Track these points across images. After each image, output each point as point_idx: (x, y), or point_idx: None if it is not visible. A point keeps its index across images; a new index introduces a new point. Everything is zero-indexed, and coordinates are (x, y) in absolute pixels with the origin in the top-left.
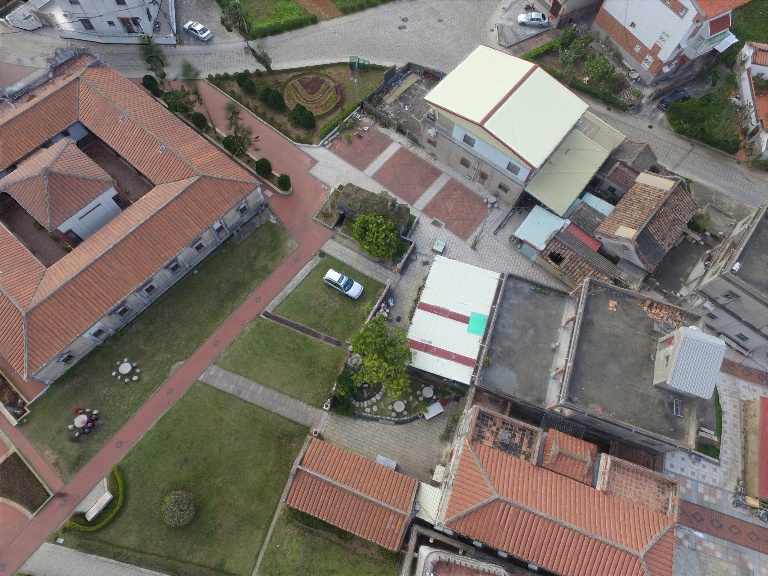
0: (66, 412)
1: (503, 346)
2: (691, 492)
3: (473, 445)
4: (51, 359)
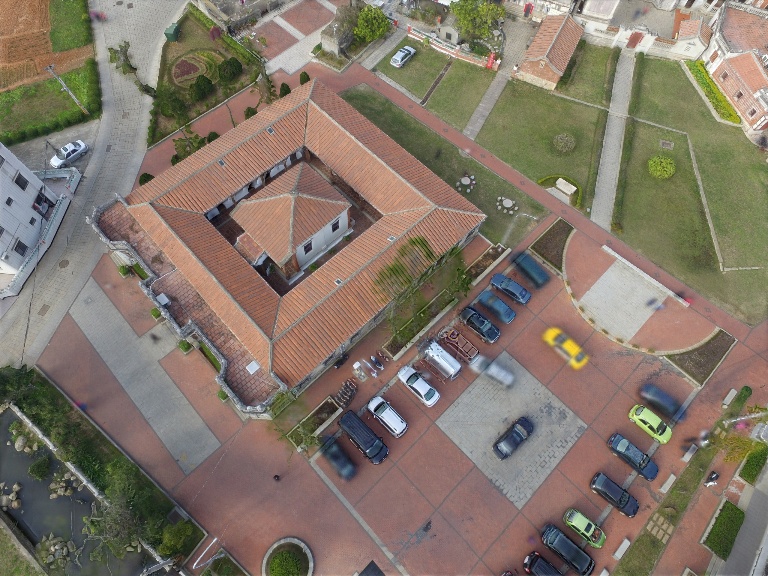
0: (498, 220)
1: None
2: None
3: None
4: (469, 202)
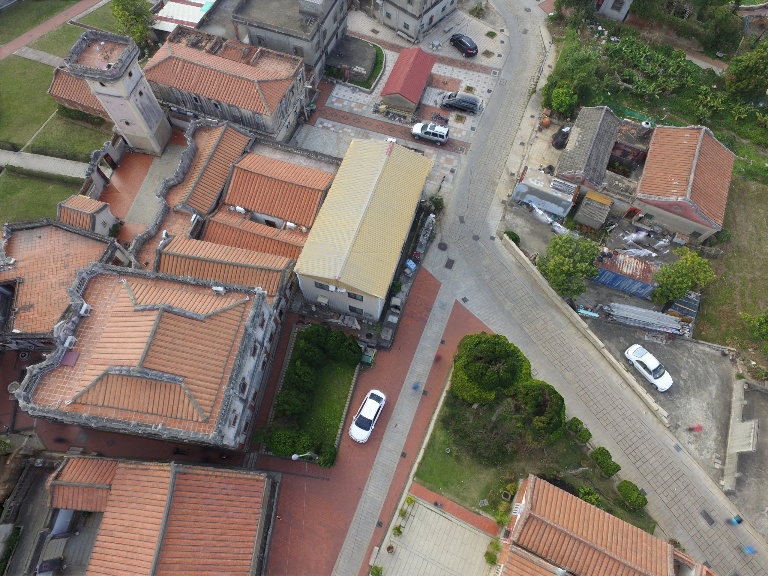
0: None
1: (221, 16)
2: (346, 106)
3: (170, 43)
4: None
